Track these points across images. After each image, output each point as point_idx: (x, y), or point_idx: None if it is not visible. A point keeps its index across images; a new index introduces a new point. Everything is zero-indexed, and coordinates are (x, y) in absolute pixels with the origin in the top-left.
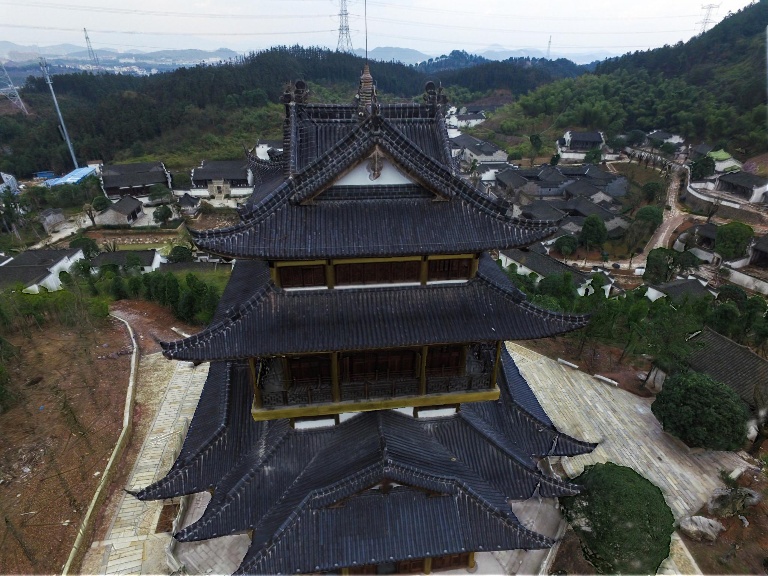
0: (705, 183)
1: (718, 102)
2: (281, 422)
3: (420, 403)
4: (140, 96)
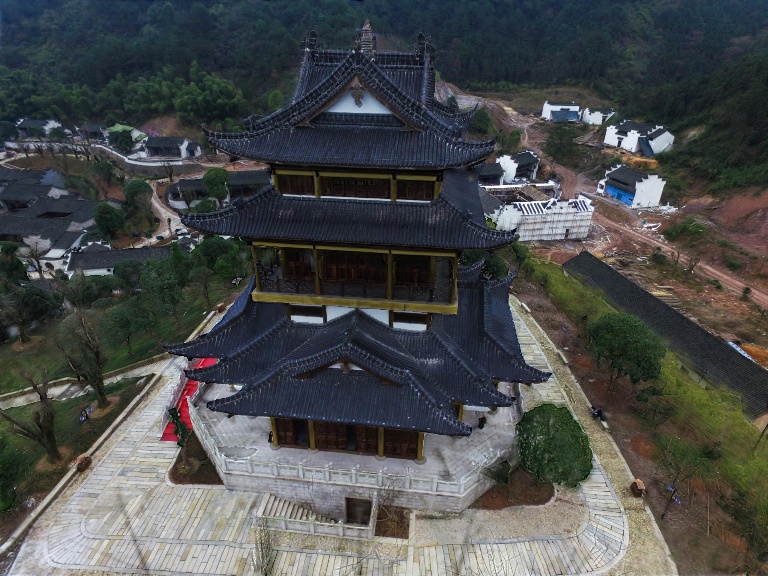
0: (136, 153)
1: (62, 83)
2: (409, 344)
3: None
4: None
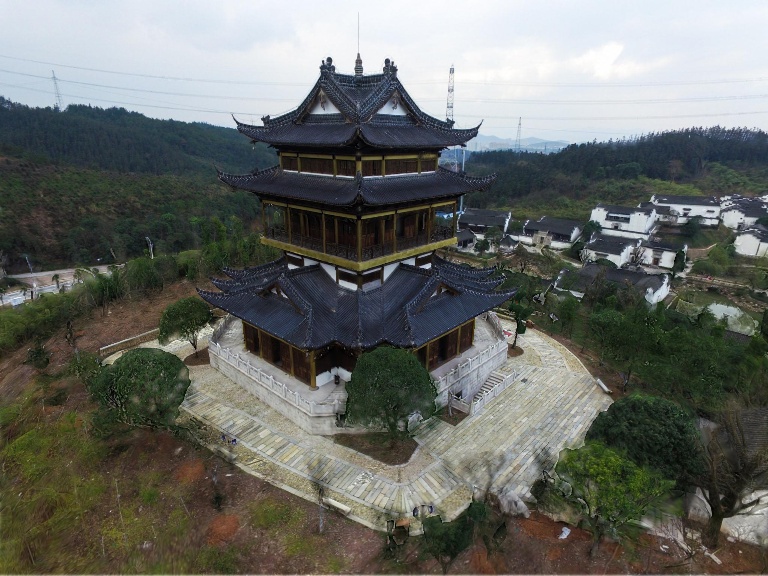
0: None
1: None
2: None
3: (321, 258)
4: (529, 165)
